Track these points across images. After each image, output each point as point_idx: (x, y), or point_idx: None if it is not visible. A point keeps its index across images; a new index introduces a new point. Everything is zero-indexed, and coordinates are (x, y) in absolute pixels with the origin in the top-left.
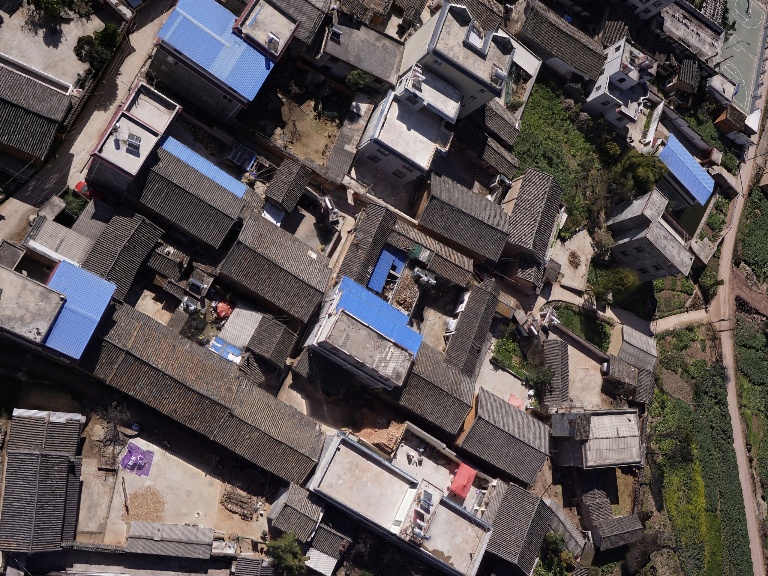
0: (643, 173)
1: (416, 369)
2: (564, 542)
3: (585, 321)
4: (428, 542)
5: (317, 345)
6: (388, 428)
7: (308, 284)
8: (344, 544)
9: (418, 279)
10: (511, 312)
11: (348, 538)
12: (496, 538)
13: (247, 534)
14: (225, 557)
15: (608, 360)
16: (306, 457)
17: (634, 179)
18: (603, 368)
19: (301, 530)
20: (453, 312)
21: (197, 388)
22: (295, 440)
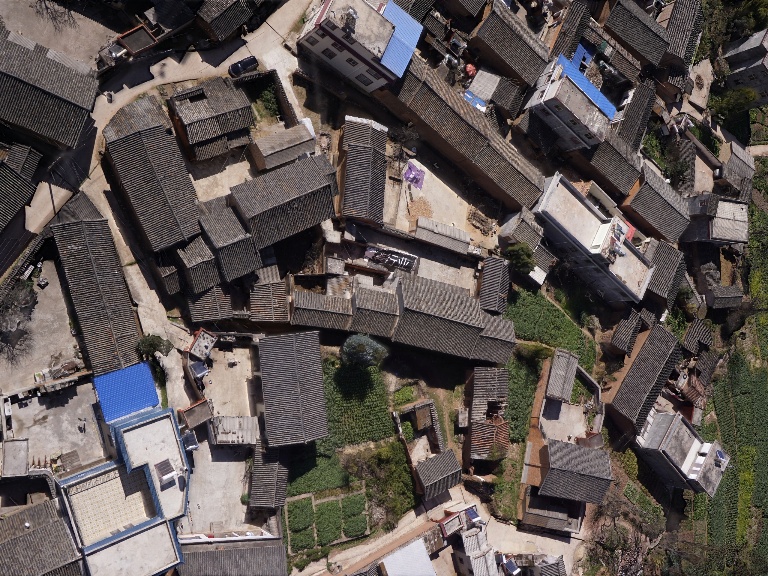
0: (763, 11)
1: (605, 137)
2: (693, 293)
3: (703, 135)
4: (612, 268)
5: (543, 103)
6: (581, 182)
7: (538, 54)
8: (554, 261)
9: (603, 70)
10: (661, 111)
11: (556, 258)
12: (651, 278)
13: (485, 245)
14: (475, 257)
15: (720, 167)
16: (536, 187)
17: (754, 17)
18: (716, 173)
19: (530, 242)
20: (618, 106)
21: (467, 120)
22: (528, 174)
